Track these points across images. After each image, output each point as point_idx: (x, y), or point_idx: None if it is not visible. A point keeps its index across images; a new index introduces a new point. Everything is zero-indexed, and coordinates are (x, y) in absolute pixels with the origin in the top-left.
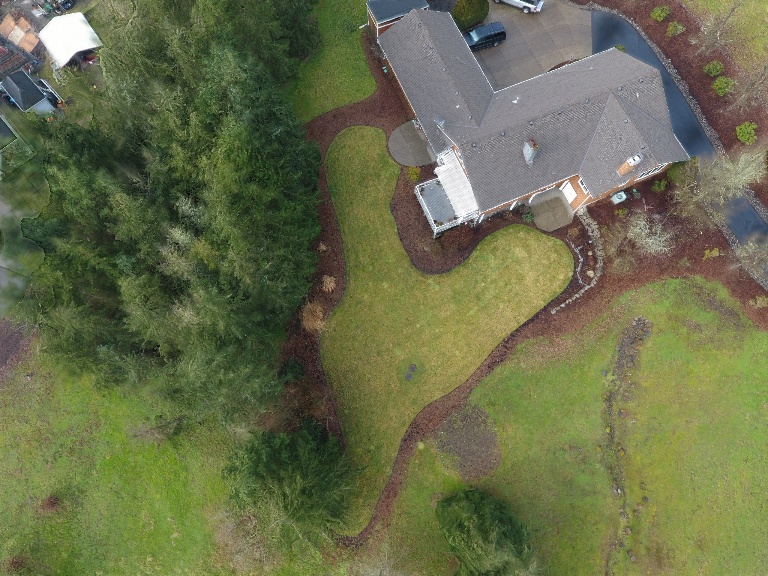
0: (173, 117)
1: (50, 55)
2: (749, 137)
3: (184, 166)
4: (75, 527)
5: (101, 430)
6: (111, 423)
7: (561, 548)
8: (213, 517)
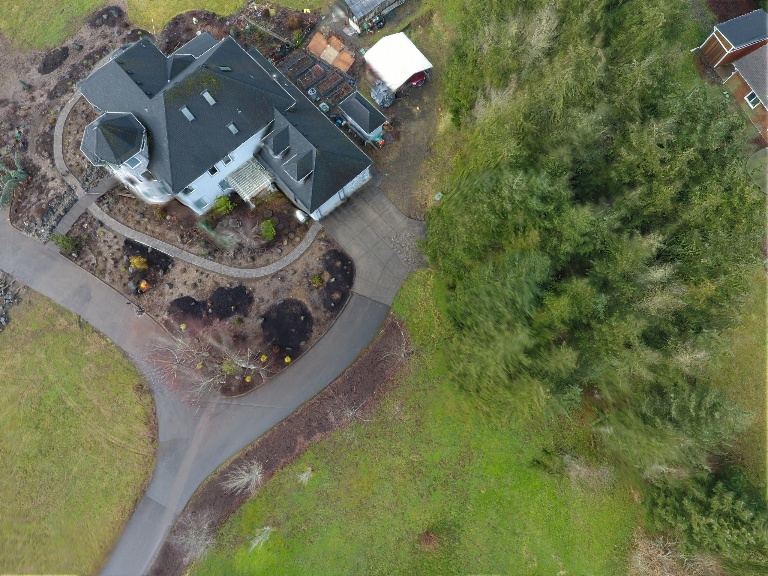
0: (664, 153)
1: (374, 76)
2: None
3: (673, 203)
4: (454, 563)
5: (474, 463)
6: (484, 456)
7: None
8: (601, 555)
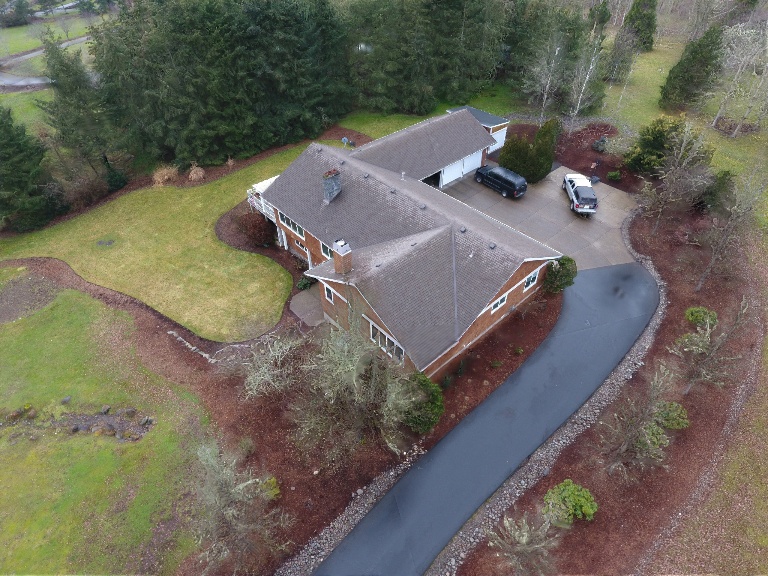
0: None
1: None
2: (556, 503)
3: None
4: None
5: None
6: None
7: None
8: None
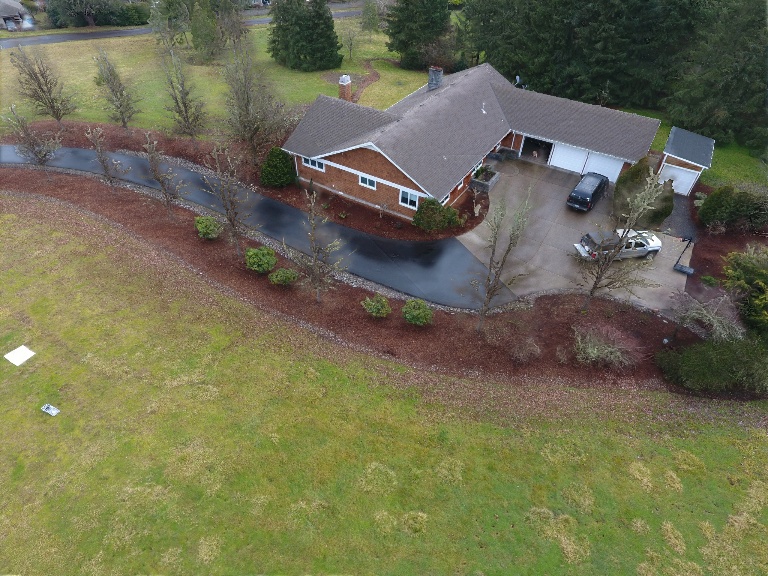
0: None
1: None
2: None
3: None
4: None
5: None
6: None
7: (266, 70)
8: None
